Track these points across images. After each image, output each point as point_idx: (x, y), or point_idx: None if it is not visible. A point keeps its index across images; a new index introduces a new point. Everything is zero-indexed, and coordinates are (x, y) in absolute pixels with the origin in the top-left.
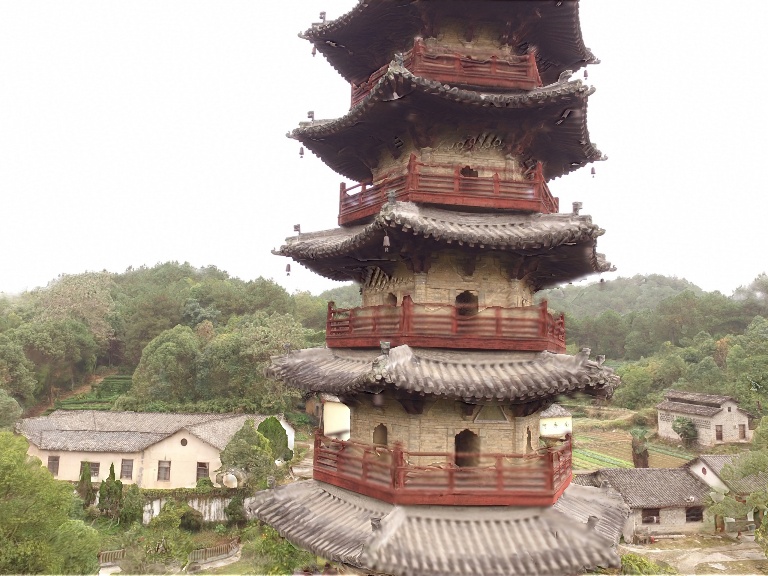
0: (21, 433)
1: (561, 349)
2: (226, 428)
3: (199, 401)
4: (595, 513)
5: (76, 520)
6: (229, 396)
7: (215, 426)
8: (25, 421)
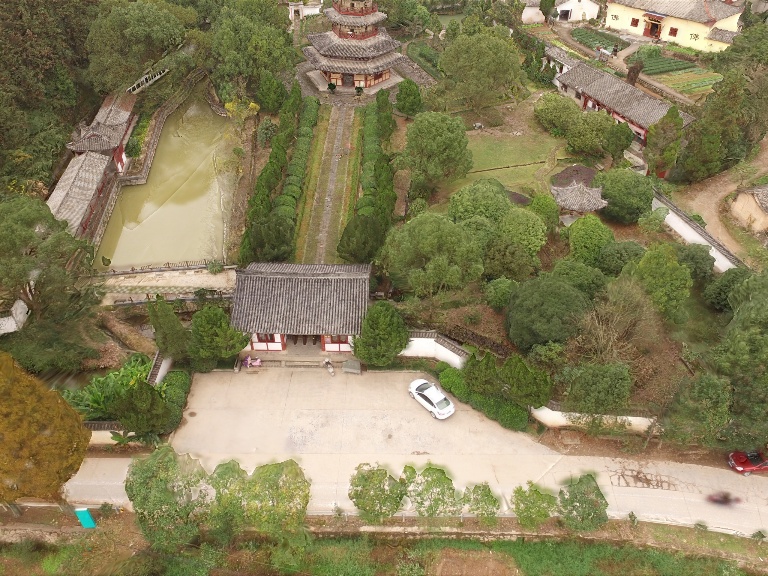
0: None
1: None
2: None
3: None
4: None
5: None
6: None
7: None
8: None
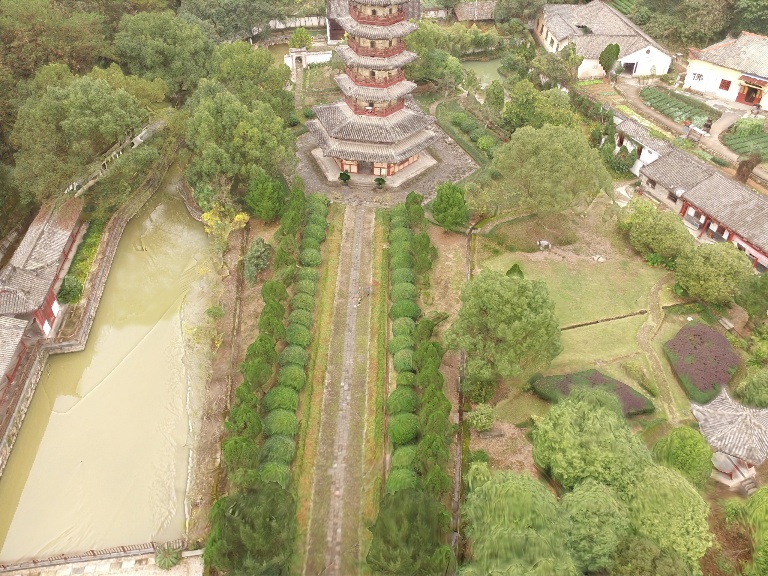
0: (544, 13)
1: (379, 55)
2: (603, 42)
3: (669, 14)
4: (381, 95)
5: (454, 62)
6: (679, 17)
7: (595, 39)
8: (555, 6)
